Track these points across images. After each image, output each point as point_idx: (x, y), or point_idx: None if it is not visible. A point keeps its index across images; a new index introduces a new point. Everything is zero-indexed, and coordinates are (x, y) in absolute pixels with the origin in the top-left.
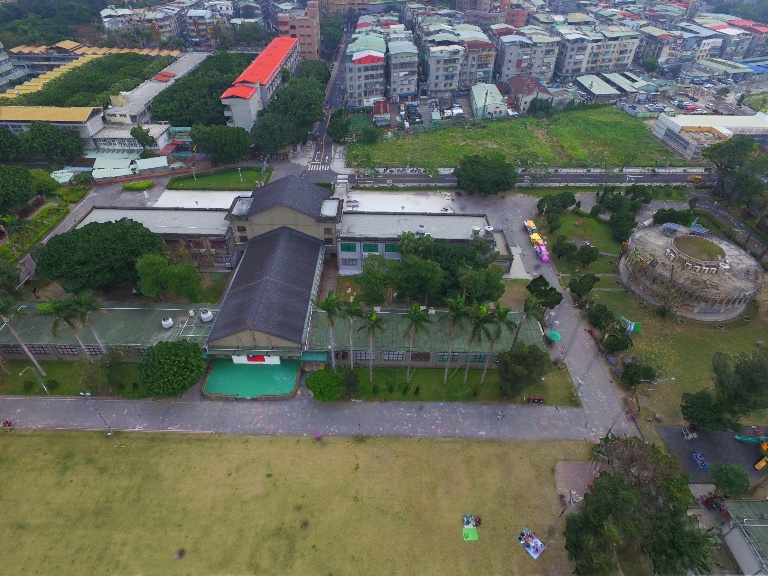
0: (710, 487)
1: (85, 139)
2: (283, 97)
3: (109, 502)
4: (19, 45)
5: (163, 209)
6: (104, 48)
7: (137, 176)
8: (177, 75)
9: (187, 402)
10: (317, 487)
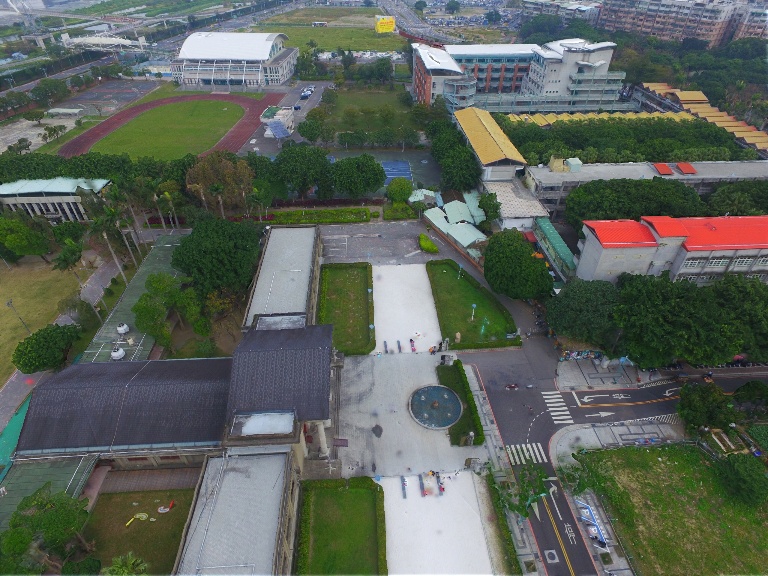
0: None
1: (480, 180)
2: (664, 282)
3: None
4: (663, 82)
5: None
6: (721, 112)
7: (446, 236)
8: (698, 175)
9: (40, 378)
10: None
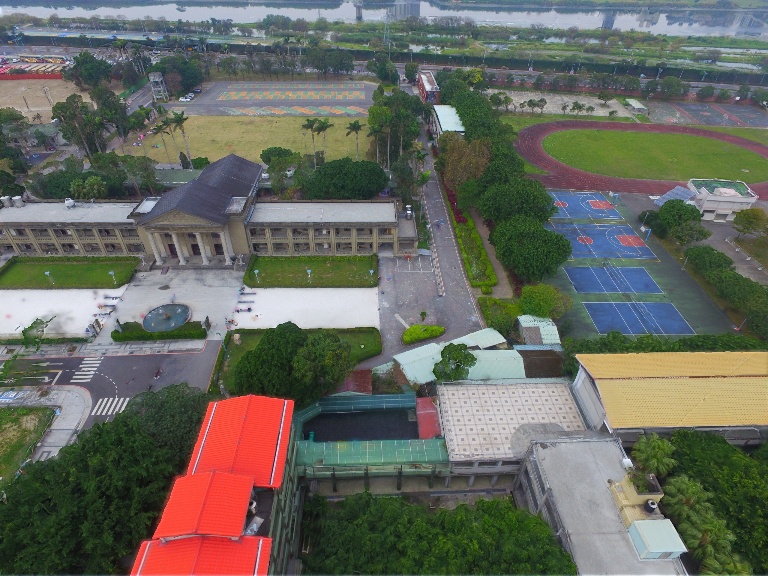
0: (44, 152)
1: None
2: None
3: (297, 150)
4: None
5: (325, 223)
6: None
7: None
8: None
9: None
10: (214, 152)
